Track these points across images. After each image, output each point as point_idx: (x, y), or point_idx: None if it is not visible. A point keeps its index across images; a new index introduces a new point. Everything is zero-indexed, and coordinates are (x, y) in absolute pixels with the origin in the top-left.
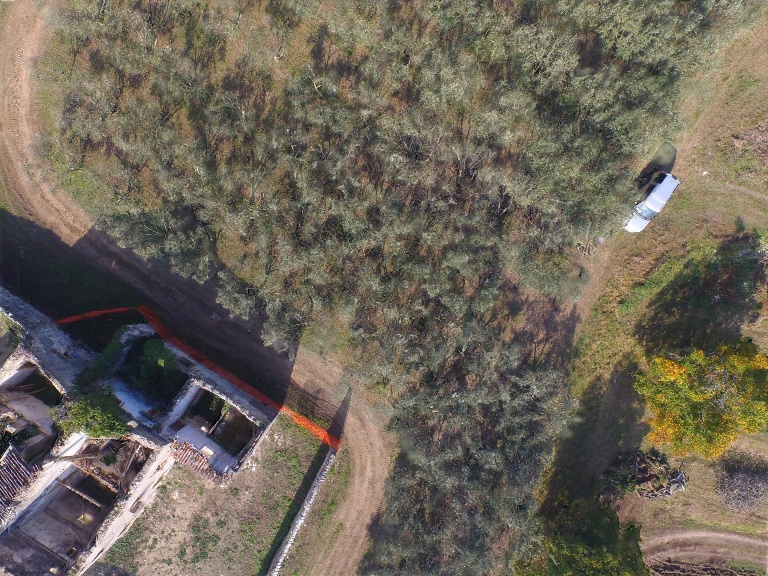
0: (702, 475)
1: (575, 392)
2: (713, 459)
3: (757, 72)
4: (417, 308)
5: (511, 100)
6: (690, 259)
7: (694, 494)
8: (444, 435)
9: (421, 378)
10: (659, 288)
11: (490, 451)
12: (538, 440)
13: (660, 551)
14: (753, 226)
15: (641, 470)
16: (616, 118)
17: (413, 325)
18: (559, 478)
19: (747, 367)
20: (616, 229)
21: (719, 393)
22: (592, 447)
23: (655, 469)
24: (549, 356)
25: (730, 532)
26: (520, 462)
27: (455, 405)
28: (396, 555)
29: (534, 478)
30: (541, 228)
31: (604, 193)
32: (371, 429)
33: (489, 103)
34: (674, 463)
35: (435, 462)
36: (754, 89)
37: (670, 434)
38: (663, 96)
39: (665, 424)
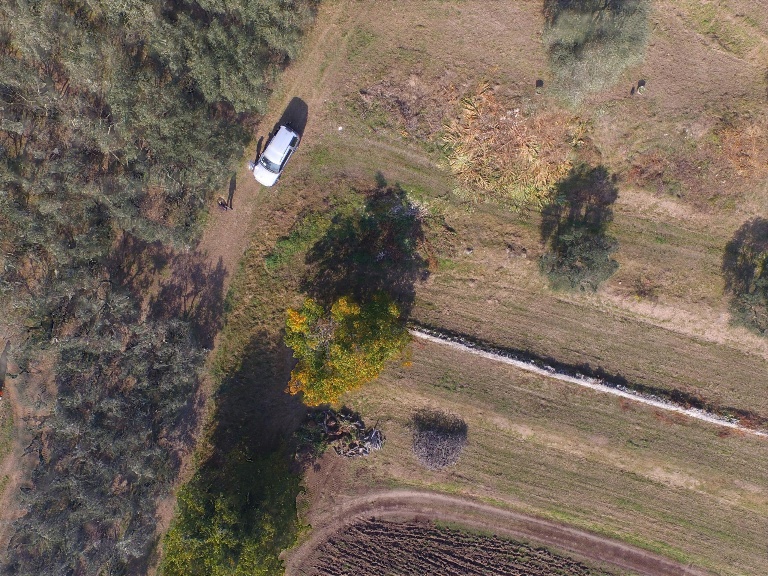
0: (398, 434)
1: (234, 346)
2: (408, 418)
3: (375, 27)
4: (31, 257)
5: (84, 48)
6: (337, 214)
7: (392, 453)
8: (102, 388)
9: (75, 331)
10: (307, 243)
11: (110, 398)
12: (163, 389)
13: (364, 510)
14: (396, 181)
15: (332, 428)
16: (196, 67)
17: (62, 278)
18: (229, 433)
19: (340, 313)
20: (213, 178)
21: (326, 341)
22: (273, 404)
23: (347, 427)
24: (200, 309)
25: (434, 492)
26: (140, 409)
27: (61, 351)
28: (33, 503)
29: (196, 431)
30: (181, 182)
31: (181, 140)
32: (32, 382)
33: (121, 58)
34: (369, 422)
35: (56, 409)
36: (374, 44)
37: (305, 384)
38: (236, 45)
39: (300, 375)
